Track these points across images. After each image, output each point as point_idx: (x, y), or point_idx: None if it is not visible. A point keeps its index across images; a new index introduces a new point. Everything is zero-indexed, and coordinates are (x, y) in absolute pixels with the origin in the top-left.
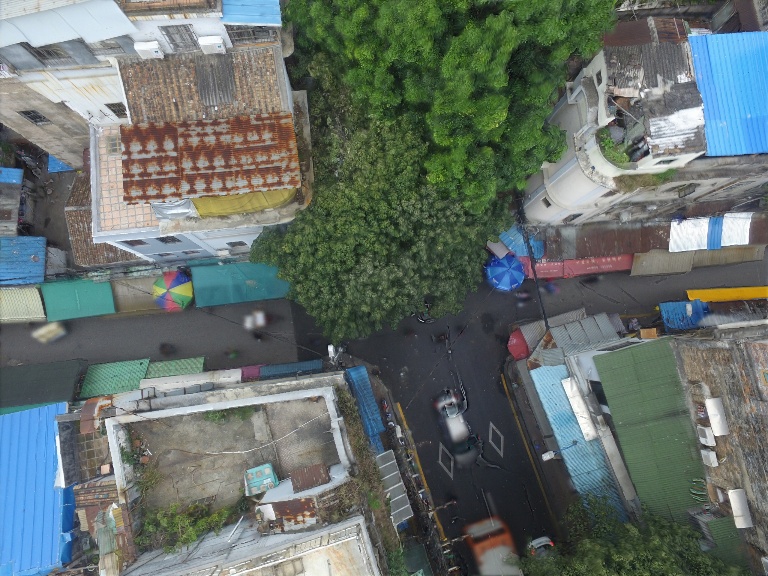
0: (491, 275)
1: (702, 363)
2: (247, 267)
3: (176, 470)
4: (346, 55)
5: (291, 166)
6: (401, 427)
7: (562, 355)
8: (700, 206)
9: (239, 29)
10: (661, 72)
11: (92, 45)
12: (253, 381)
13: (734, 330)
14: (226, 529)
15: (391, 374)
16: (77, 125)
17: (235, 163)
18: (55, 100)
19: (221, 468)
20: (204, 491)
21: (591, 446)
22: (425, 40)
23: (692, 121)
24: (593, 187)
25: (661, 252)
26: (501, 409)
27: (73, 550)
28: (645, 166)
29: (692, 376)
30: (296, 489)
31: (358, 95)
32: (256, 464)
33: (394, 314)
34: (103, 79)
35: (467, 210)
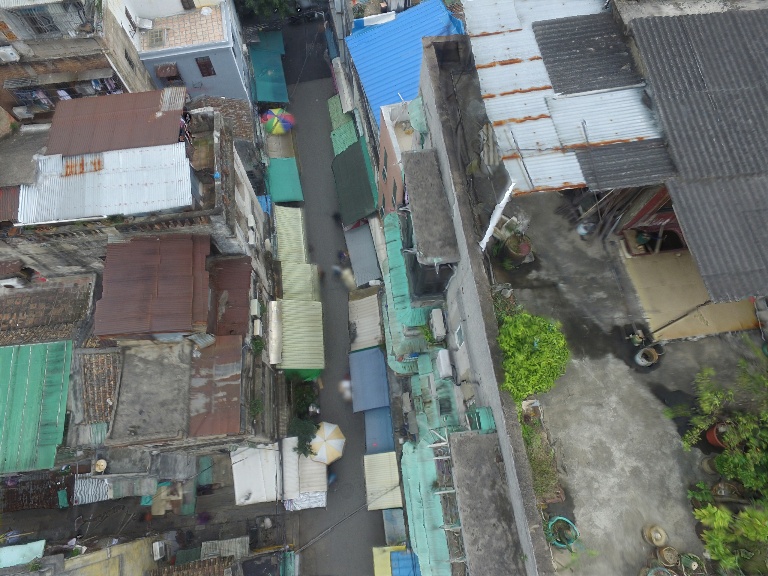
0: None
1: None
2: (257, 67)
3: None
4: None
5: None
6: None
7: None
8: None
9: None
10: None
11: None
12: None
13: None
14: None
15: None
16: (138, 60)
17: None
18: (120, 23)
19: None
20: None
21: None
22: None
23: None
24: None
25: None
26: None
27: None
28: None
29: None
30: None
31: None
32: None
33: None
34: None
35: None
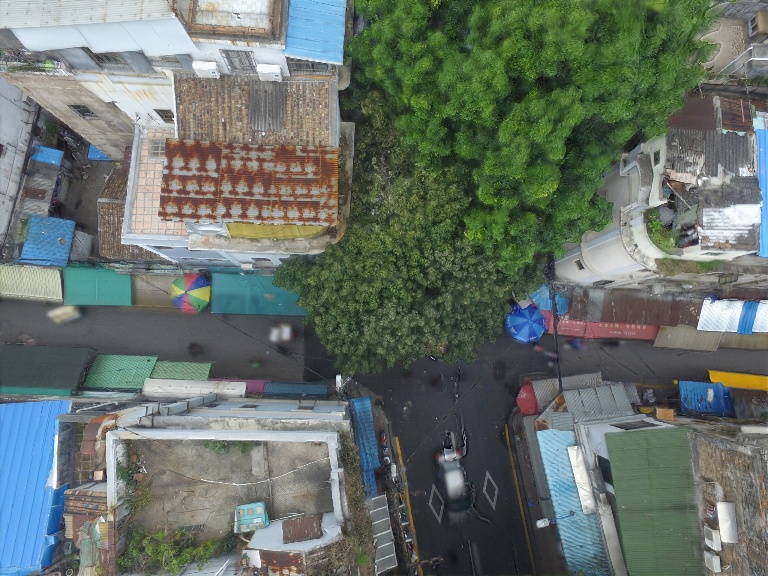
0: (510, 324)
1: (719, 462)
2: (267, 281)
3: (168, 492)
4: (402, 99)
5: (330, 203)
6: (396, 462)
7: (572, 421)
8: (737, 291)
9: (299, 61)
10: (723, 162)
11: (151, 57)
12: (256, 398)
13: (759, 436)
14: (209, 563)
15: (394, 407)
16: (123, 123)
17: (274, 192)
18: (106, 100)
19: (213, 497)
20: (193, 518)
21: (588, 519)
22: (486, 103)
23: (748, 218)
24: (632, 263)
25: (688, 327)
26: (500, 460)
27: (54, 553)
28: (691, 254)
29: (706, 472)
30: (286, 539)
31: (408, 140)
32: (249, 499)
33: (408, 355)
34: (156, 88)
35: (500, 269)
